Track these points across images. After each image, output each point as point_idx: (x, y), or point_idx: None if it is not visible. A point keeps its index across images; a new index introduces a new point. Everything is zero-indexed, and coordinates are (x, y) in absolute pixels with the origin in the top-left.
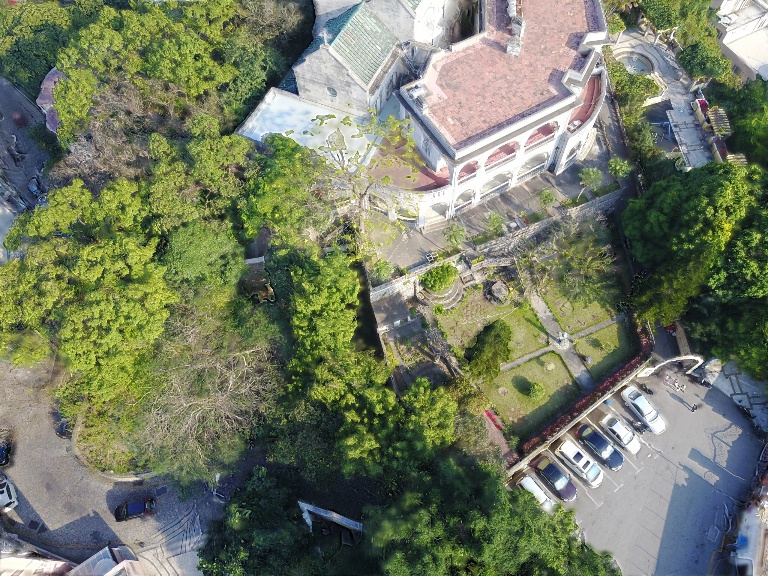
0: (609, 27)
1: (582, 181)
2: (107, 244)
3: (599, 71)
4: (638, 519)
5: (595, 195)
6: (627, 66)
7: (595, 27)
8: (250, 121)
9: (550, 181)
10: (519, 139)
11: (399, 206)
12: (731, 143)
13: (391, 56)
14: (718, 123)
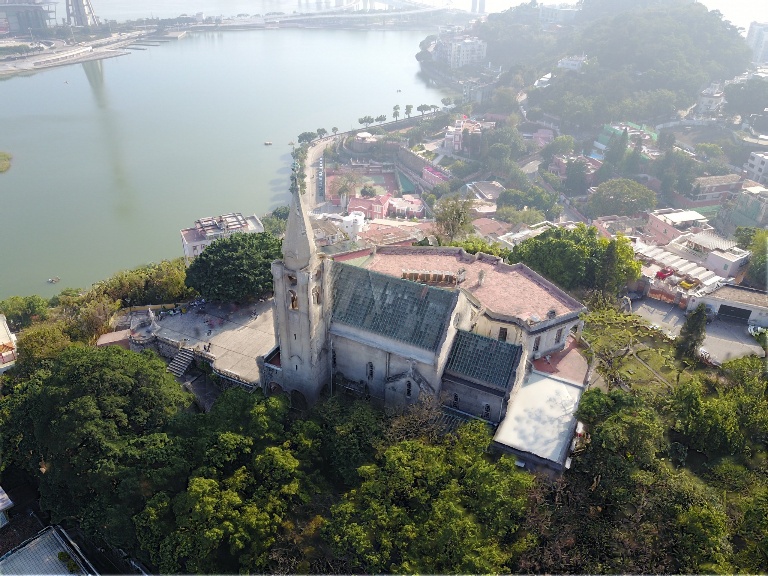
0: None
1: None
2: None
3: None
4: None
5: None
6: None
7: (451, 253)
8: None
9: None
10: None
11: None
12: None
13: None
14: None
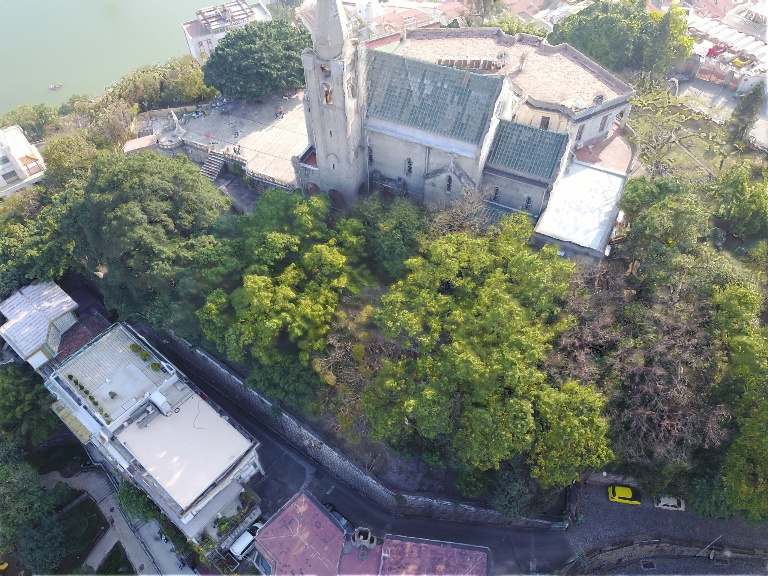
0: None
1: None
2: None
3: None
4: (763, 128)
5: None
6: None
7: (488, 35)
8: None
9: None
10: None
11: None
12: None
13: None
14: None
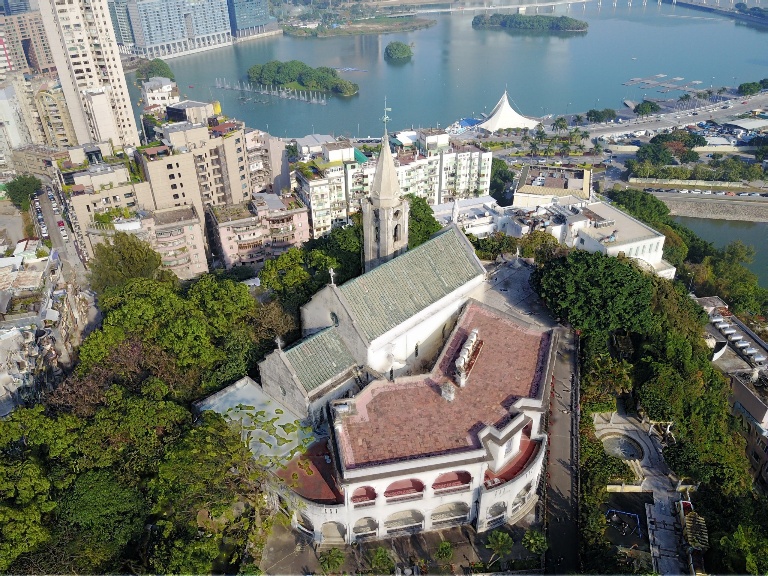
0: (598, 405)
1: (489, 544)
2: (15, 464)
3: (541, 437)
4: None
5: (511, 567)
6: (616, 447)
7: (536, 395)
8: (213, 398)
9: (469, 537)
10: (423, 478)
11: (299, 514)
12: (709, 560)
13: (346, 374)
14: (694, 532)
